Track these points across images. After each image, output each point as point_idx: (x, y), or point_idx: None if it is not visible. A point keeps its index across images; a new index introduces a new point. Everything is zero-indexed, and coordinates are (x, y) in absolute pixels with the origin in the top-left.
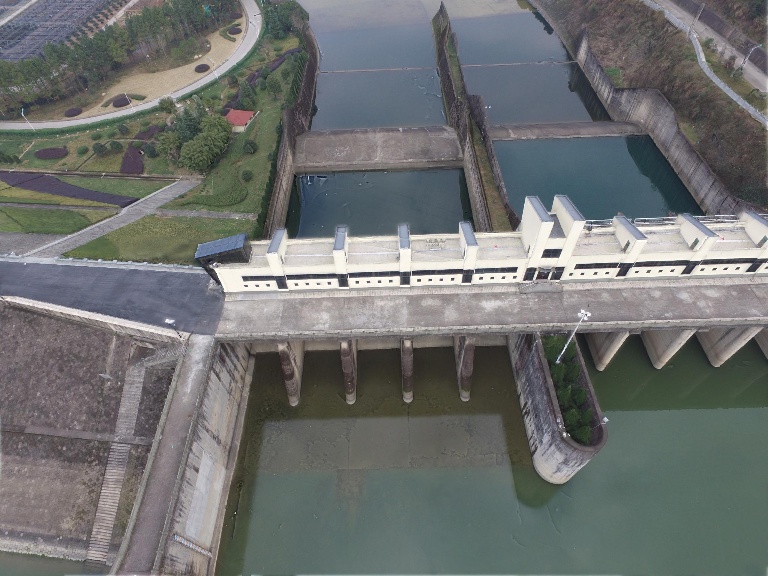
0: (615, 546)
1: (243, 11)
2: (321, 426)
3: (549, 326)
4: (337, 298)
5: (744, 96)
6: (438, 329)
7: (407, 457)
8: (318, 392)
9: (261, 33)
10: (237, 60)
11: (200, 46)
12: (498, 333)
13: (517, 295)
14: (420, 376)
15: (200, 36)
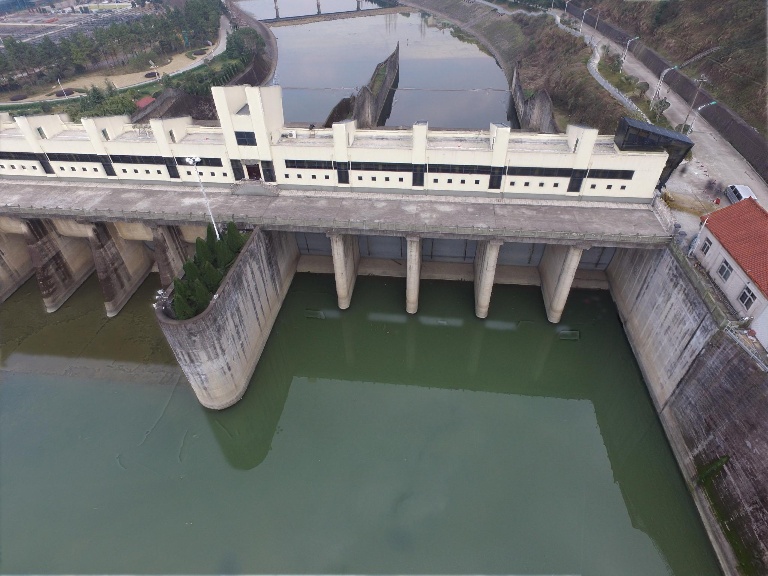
0: (236, 483)
1: (217, 41)
2: (3, 328)
3: (229, 216)
4: (43, 186)
5: (615, 83)
6: (108, 209)
7: (67, 365)
8: (27, 299)
9: (220, 54)
10: (185, 70)
11: (160, 60)
12: (176, 222)
13: (228, 196)
14: (143, 296)
15: (164, 53)
